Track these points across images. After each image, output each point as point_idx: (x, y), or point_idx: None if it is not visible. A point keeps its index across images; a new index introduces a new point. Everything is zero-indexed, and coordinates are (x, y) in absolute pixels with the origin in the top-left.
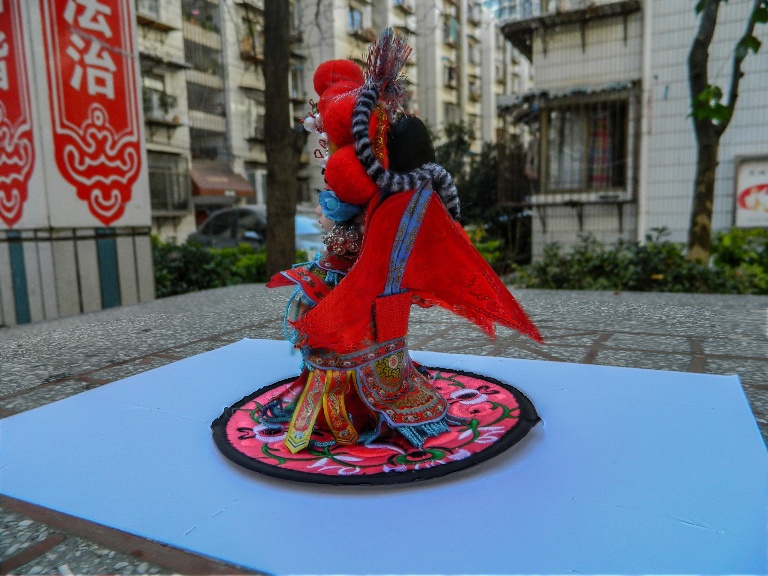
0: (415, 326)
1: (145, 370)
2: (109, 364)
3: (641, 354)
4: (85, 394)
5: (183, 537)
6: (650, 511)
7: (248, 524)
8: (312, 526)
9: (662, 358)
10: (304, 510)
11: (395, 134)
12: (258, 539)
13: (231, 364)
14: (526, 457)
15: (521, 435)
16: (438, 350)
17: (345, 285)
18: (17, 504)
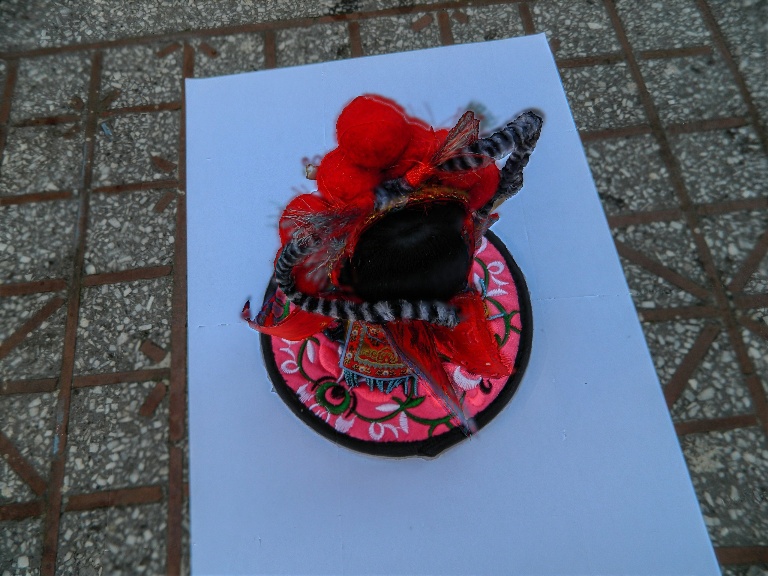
0: (733, 157)
1: (401, 48)
2: (396, 5)
3: (766, 481)
4: (327, 67)
5: (196, 328)
6: (346, 568)
7: (221, 349)
8: (236, 383)
9: (763, 509)
10: (248, 367)
11: (361, 262)
12: (211, 366)
13: (455, 101)
14: (387, 462)
15: (392, 454)
16: (627, 252)
17: (264, 330)
18: (182, 215)
